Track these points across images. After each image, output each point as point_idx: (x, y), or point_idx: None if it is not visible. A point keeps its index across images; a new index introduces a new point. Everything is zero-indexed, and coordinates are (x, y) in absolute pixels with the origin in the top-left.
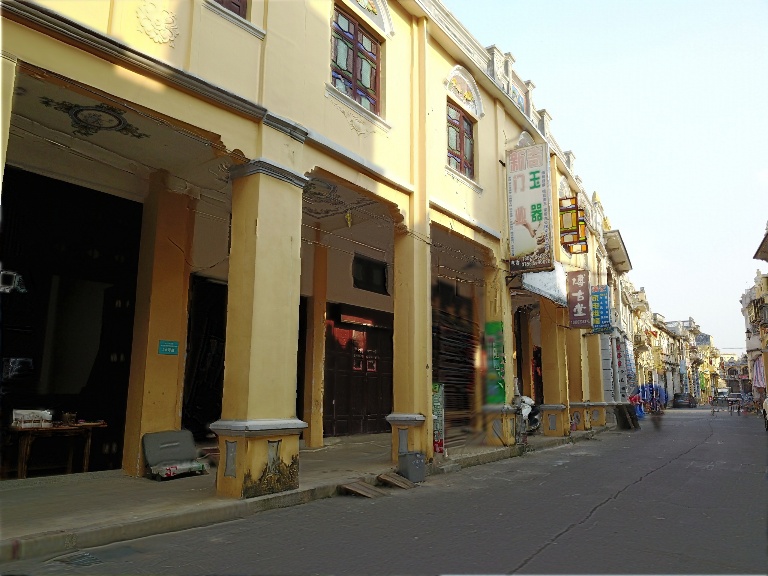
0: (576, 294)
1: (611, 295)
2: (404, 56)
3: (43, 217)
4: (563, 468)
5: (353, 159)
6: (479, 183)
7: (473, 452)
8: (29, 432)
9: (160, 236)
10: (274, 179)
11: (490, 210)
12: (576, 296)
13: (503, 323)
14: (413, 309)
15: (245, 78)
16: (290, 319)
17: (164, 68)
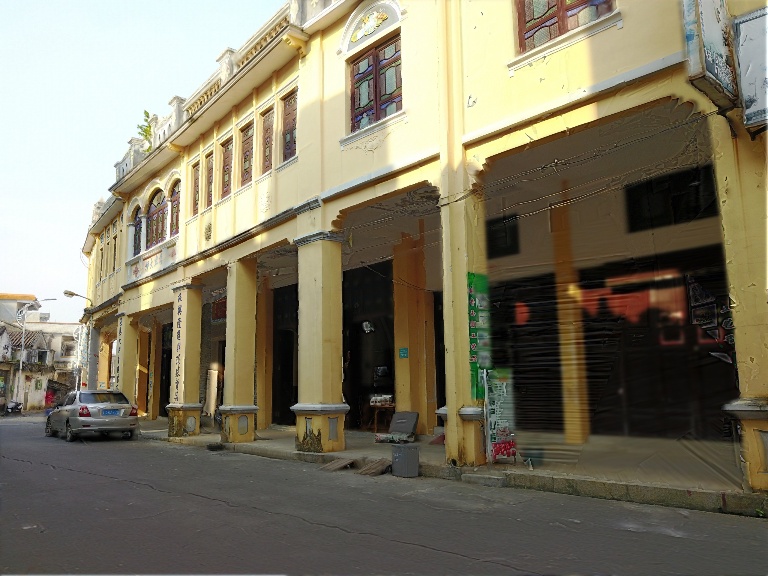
0: None
1: None
2: (429, 9)
3: (371, 287)
4: (542, 522)
5: (361, 182)
6: (616, 5)
7: (605, 477)
8: (376, 408)
9: (395, 278)
10: None
11: (664, 21)
12: None
13: (724, 224)
14: None
15: (295, 192)
16: (316, 335)
17: (260, 226)
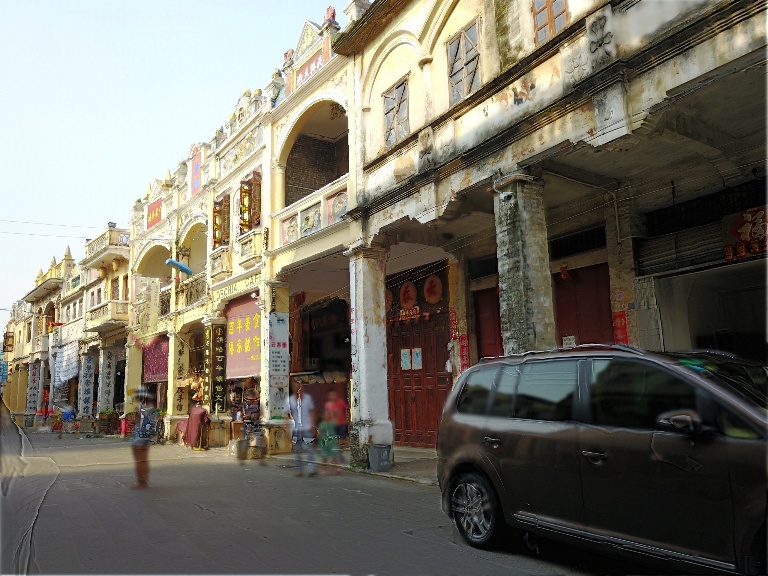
0: None
1: (56, 318)
2: None
3: None
4: None
5: None
6: None
7: None
8: None
9: None
10: None
11: None
12: None
13: None
14: None
15: None
16: None
17: None
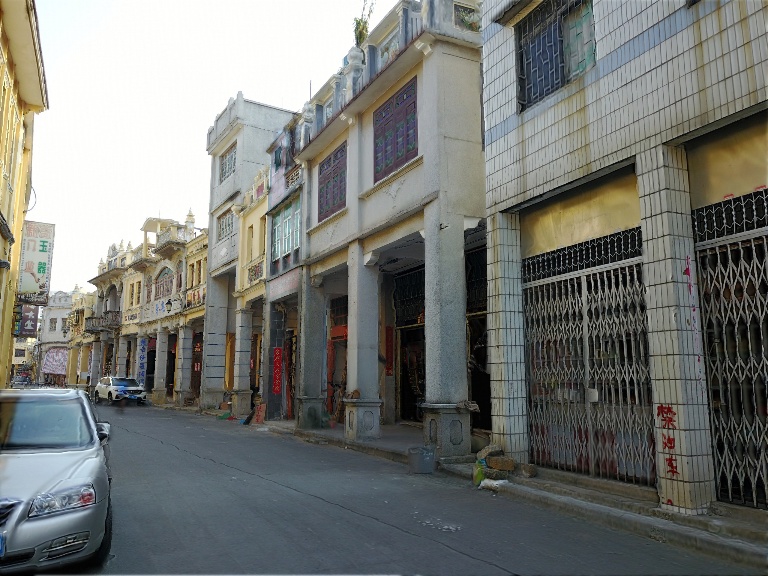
0: (28, 314)
1: None
2: None
3: None
4: None
5: None
6: None
7: None
8: None
9: None
10: (6, 270)
11: None
12: (28, 315)
13: None
14: (3, 332)
15: None
16: None
17: None
